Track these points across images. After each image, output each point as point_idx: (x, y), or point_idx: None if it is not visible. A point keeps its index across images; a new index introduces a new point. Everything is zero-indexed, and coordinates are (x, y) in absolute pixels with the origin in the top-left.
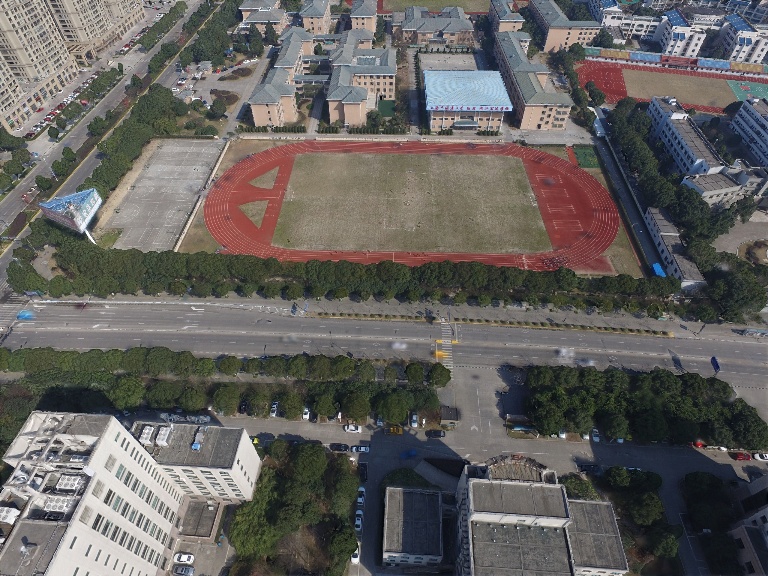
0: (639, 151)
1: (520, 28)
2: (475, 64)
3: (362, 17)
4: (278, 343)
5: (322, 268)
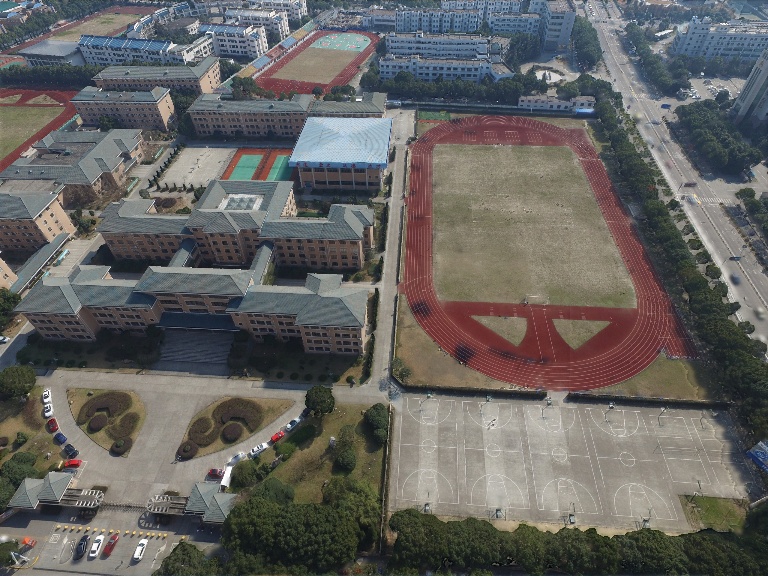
0: (461, 83)
1: (170, 99)
2: (216, 148)
3: (45, 207)
4: (765, 290)
5: (685, 246)
